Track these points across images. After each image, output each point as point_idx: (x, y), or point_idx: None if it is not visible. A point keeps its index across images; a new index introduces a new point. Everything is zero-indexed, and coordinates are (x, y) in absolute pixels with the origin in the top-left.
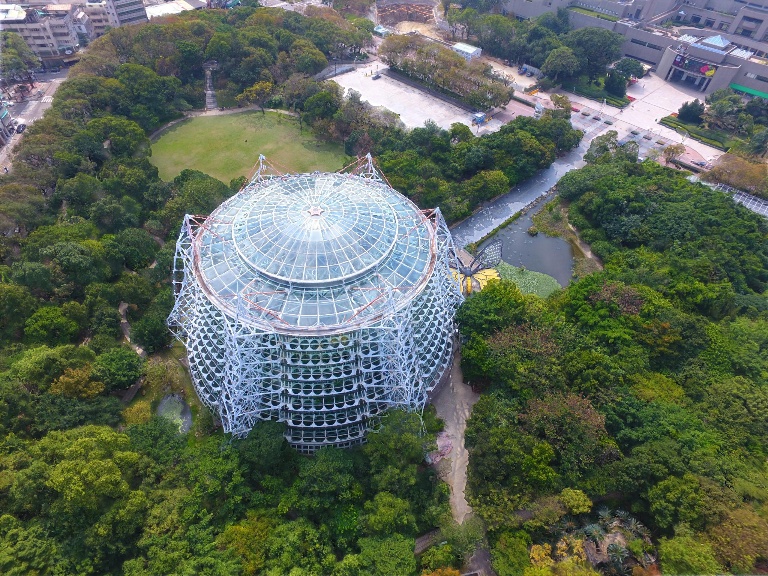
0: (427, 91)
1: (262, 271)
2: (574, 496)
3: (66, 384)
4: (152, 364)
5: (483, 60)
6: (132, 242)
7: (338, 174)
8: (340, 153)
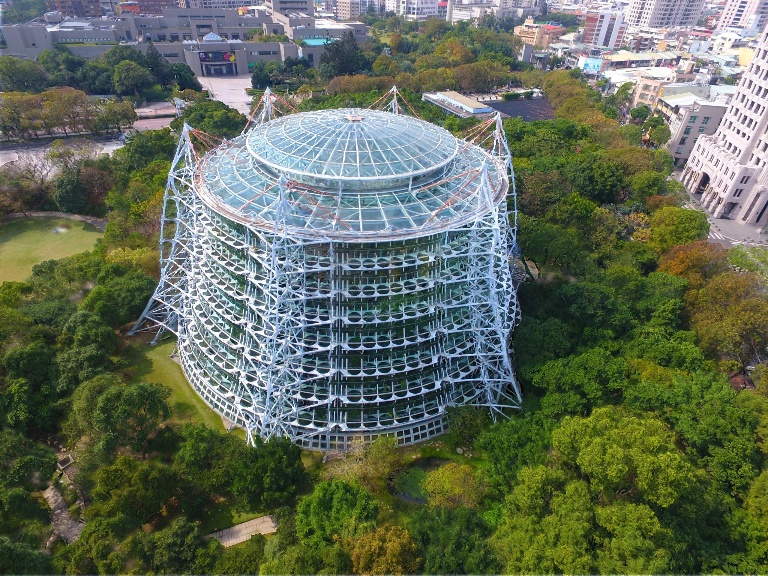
0: (21, 147)
1: (423, 171)
2: (599, 210)
3: (400, 555)
4: (353, 464)
5: (69, 87)
6: (5, 456)
7: (243, 134)
8: (43, 225)
